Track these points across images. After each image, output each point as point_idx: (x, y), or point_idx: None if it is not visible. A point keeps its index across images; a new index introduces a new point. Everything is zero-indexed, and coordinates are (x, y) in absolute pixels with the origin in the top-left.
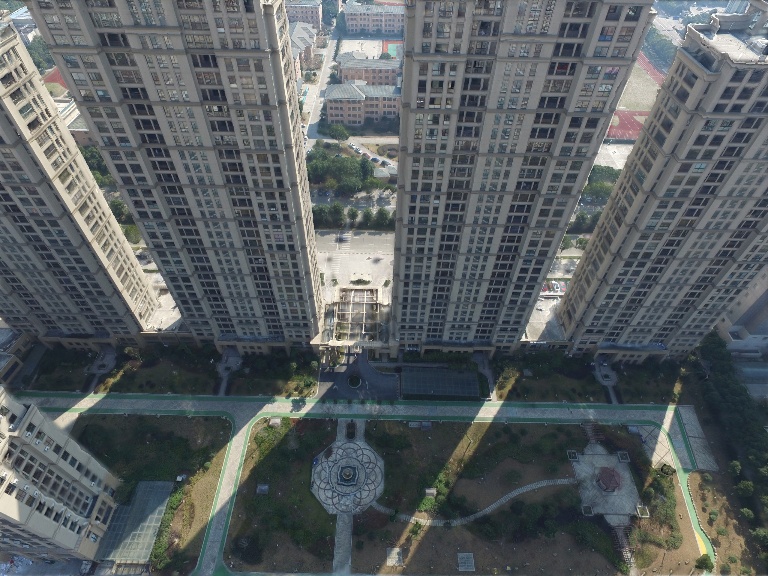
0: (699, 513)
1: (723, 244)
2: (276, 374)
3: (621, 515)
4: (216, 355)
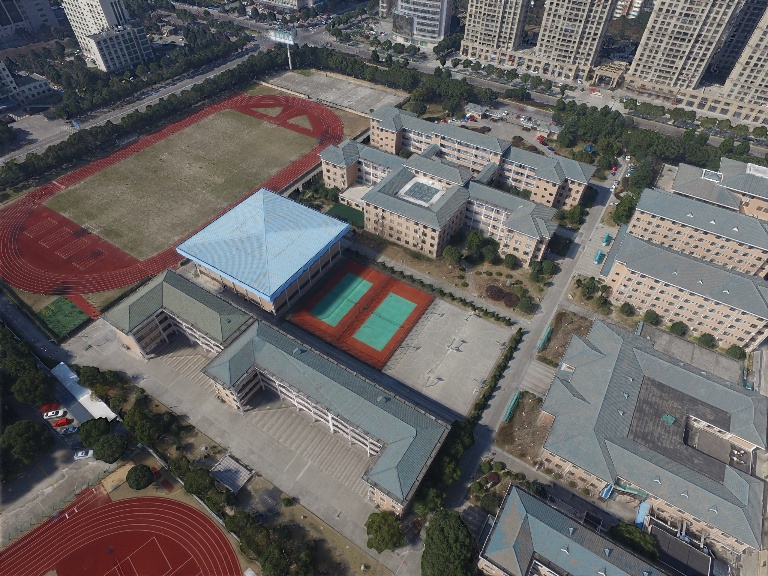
0: None
1: None
2: None
3: None
4: None
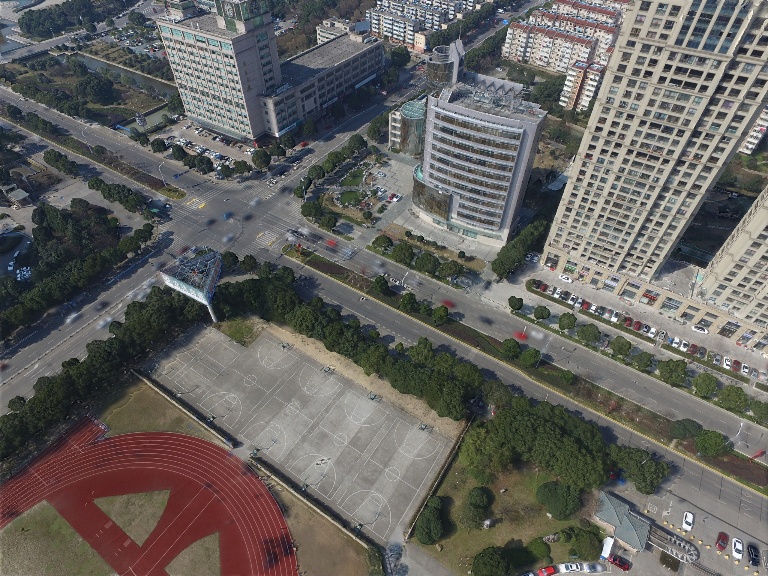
0: None
1: None
2: None
3: None
4: None
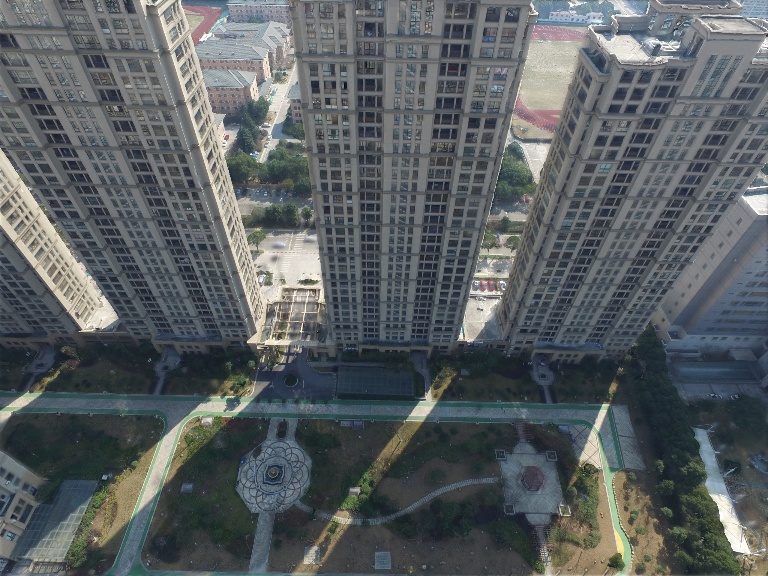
0: (621, 512)
1: (642, 244)
2: (213, 373)
3: (543, 514)
4: (154, 354)
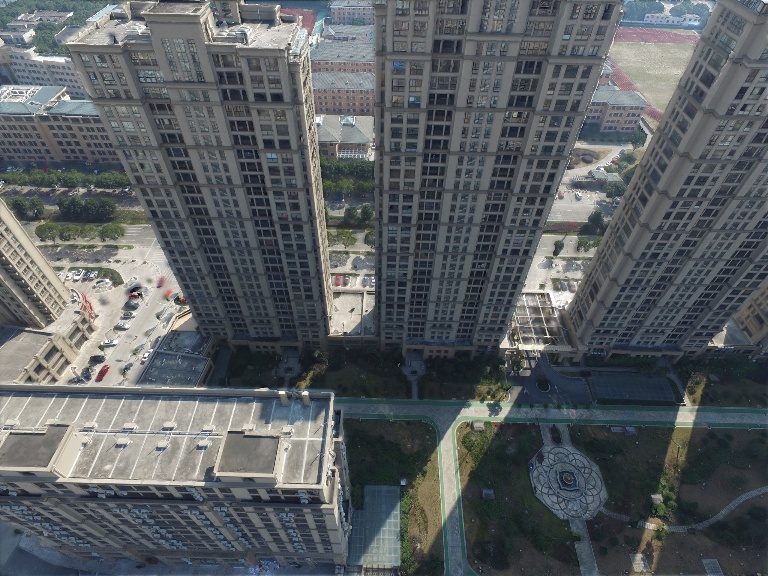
0: None
1: None
2: (465, 378)
3: None
4: (401, 359)
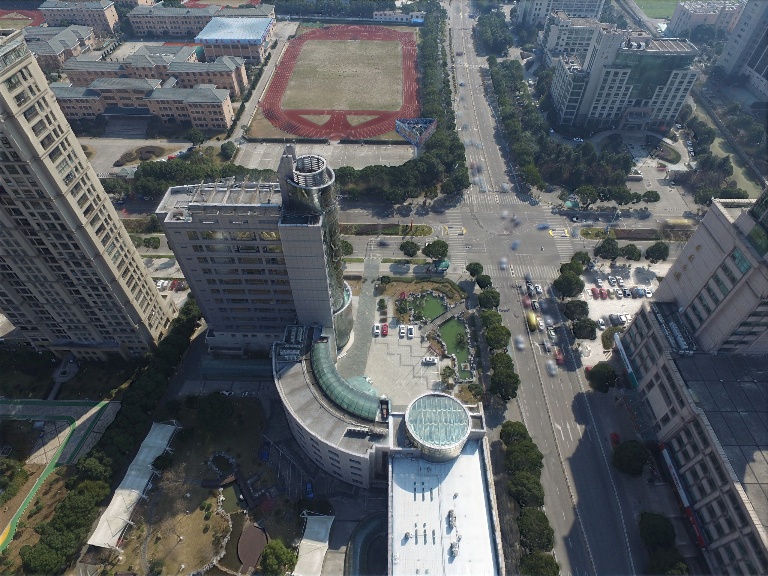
0: (28, 507)
1: (25, 242)
2: None
3: None
4: None
